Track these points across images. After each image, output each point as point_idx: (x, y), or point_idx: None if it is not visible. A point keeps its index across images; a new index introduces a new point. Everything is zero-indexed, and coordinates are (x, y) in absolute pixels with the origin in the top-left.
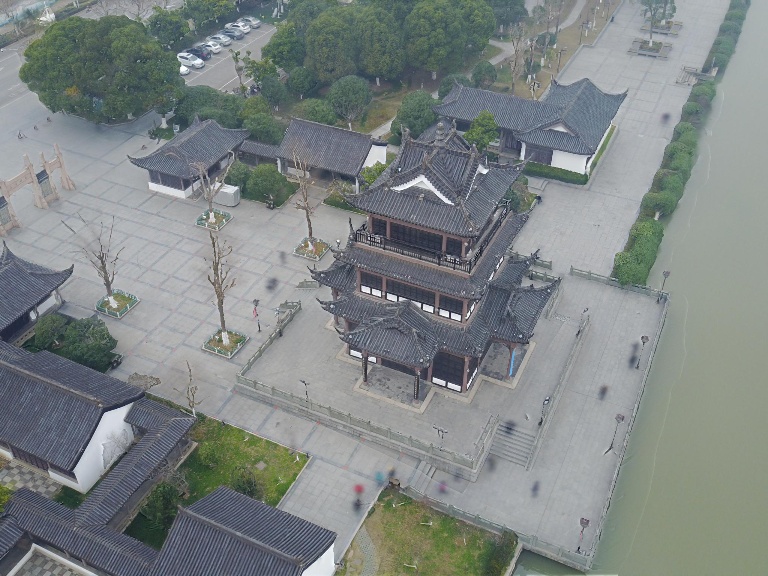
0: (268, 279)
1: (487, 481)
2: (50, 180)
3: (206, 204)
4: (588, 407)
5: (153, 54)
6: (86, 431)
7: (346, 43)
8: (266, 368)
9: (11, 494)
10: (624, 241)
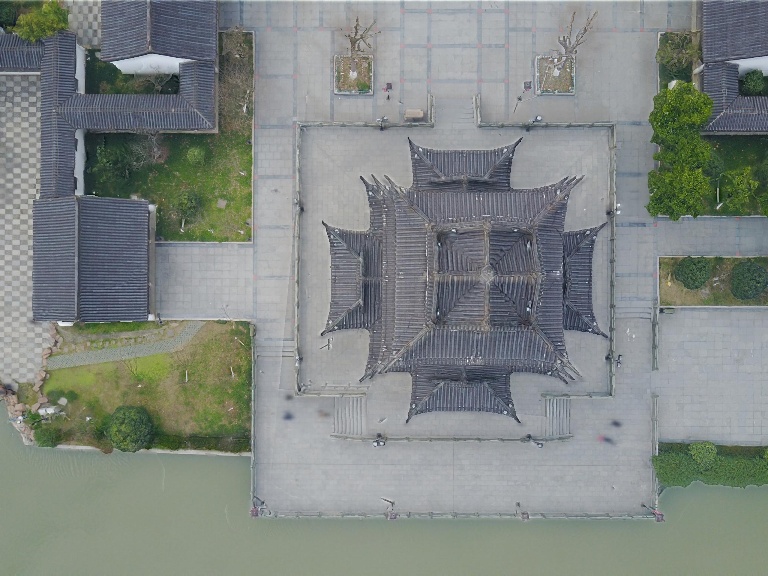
0: (477, 55)
1: (302, 405)
2: None
3: None
4: (437, 469)
5: None
6: (131, 50)
7: None
8: (330, 141)
9: (58, 32)
10: (756, 441)
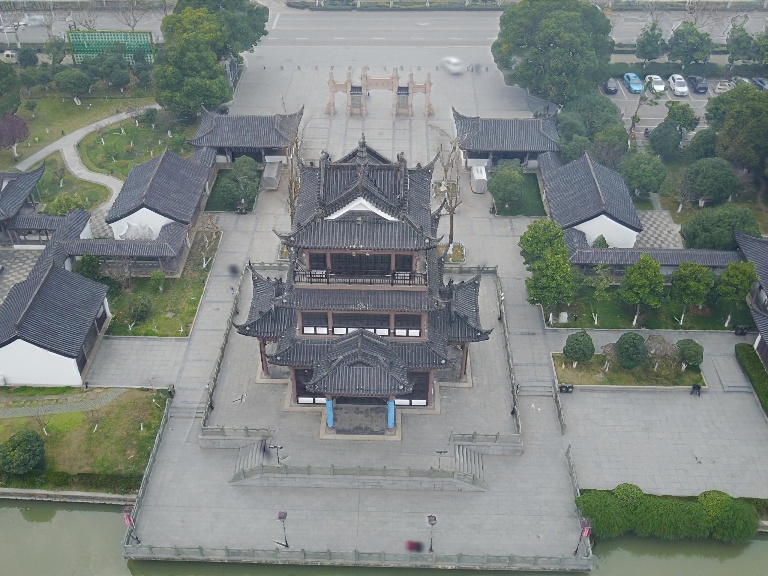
0: None
1: (205, 455)
2: (410, 98)
3: (466, 178)
4: (341, 514)
5: (567, 44)
6: (129, 208)
7: (759, 127)
8: None
9: (80, 209)
10: (687, 495)
